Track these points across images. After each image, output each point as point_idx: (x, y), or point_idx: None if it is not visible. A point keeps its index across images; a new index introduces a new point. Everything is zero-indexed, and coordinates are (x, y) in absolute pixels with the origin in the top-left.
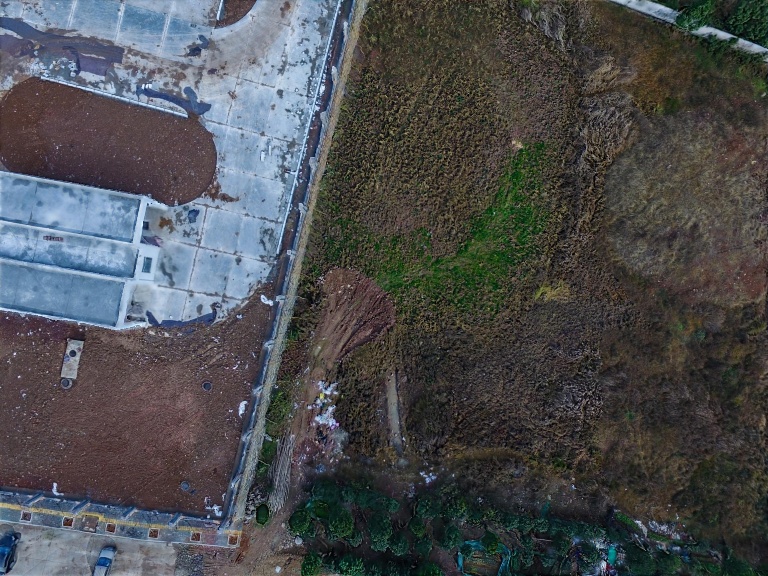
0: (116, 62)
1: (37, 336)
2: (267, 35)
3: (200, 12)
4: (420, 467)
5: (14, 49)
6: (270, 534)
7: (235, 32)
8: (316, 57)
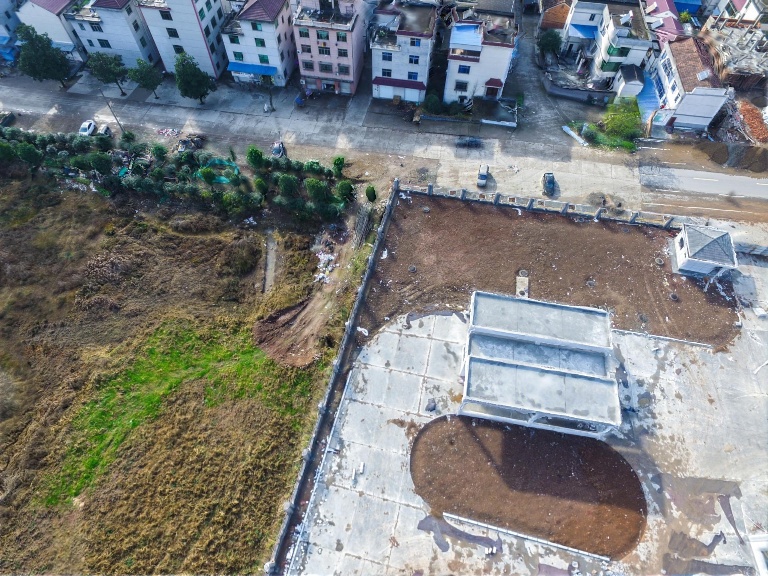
0: None
1: None
2: None
3: None
4: (256, 227)
5: None
6: None
7: None
8: None
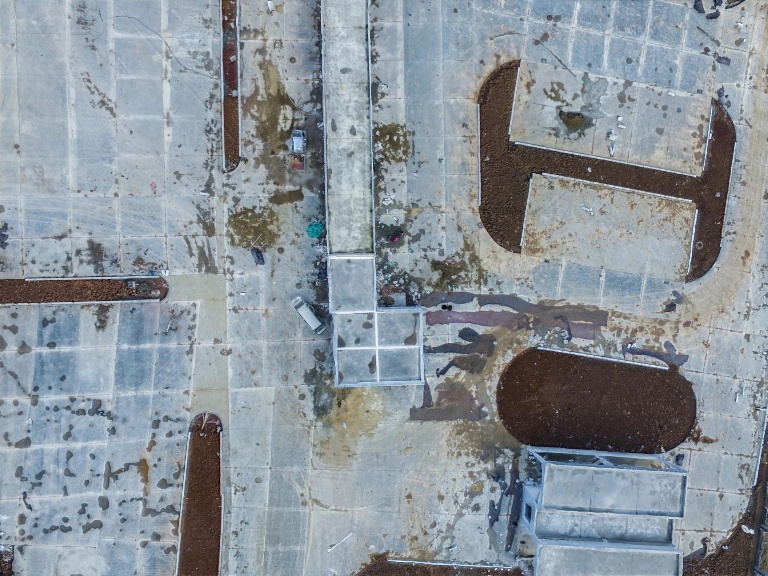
0: (602, 325)
1: None
2: (732, 284)
3: (671, 269)
4: None
5: (511, 324)
6: None
7: (703, 284)
8: None
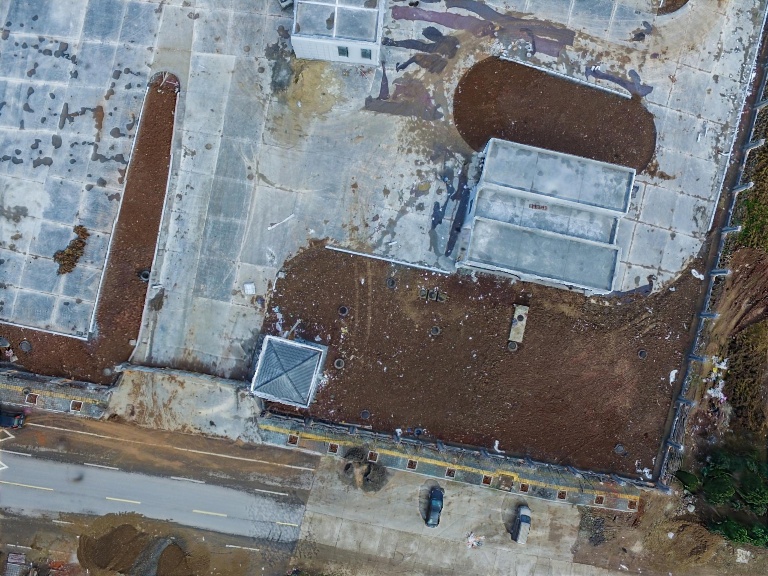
0: (568, 44)
1: (487, 300)
2: (705, 23)
3: None
4: None
5: (476, 30)
6: (664, 501)
7: (675, 19)
8: (749, 45)
